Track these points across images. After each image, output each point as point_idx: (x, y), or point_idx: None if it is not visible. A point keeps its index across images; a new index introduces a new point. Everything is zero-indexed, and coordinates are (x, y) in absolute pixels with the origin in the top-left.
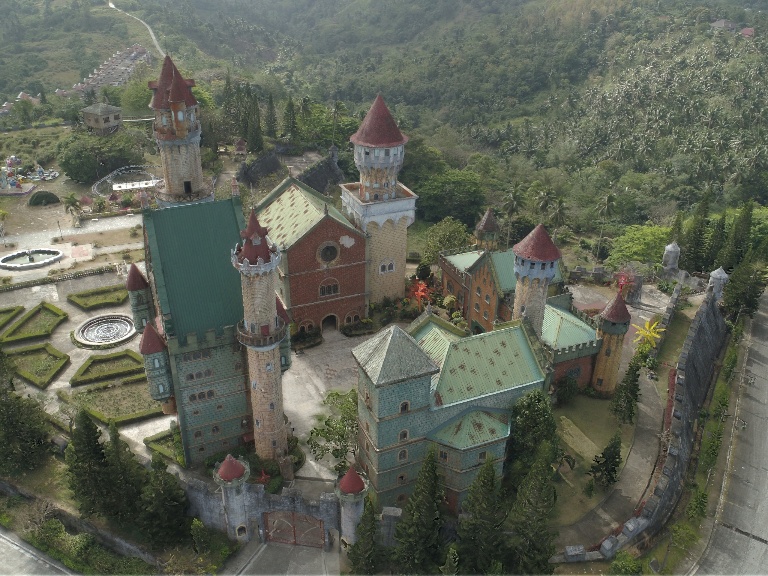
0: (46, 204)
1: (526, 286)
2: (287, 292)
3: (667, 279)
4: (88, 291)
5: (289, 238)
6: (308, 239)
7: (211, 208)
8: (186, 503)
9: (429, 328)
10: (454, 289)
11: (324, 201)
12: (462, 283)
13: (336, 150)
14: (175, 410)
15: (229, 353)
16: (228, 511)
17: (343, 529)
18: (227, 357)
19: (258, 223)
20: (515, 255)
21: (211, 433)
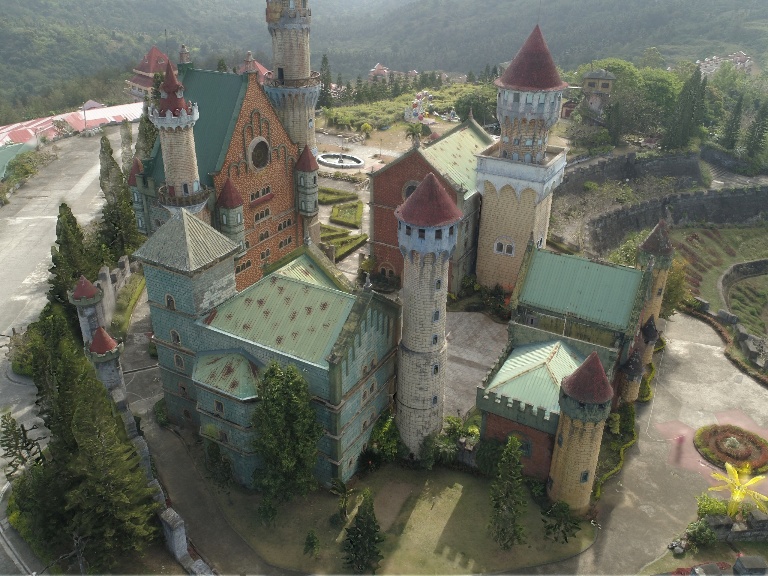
0: None
1: None
2: (371, 222)
3: None
4: (319, 187)
5: None
6: (395, 170)
7: (228, 79)
8: None
9: None
10: None
11: None
12: None
13: None
14: None
15: None
16: None
17: None
18: None
19: (172, 78)
20: None
21: None
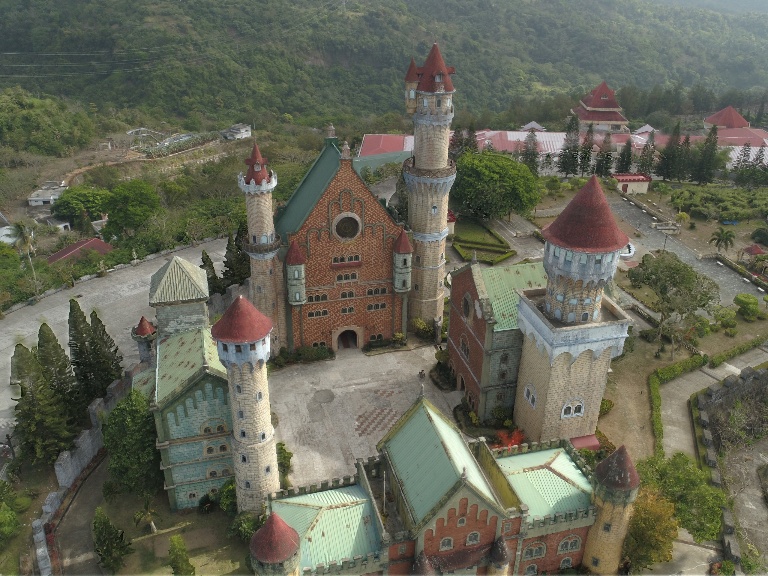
0: (758, 242)
1: None
2: None
3: None
4: None
5: None
6: None
7: None
8: None
9: None
10: None
11: None
12: None
13: None
14: None
15: None
16: None
17: None
18: None
19: (255, 154)
20: None
21: None
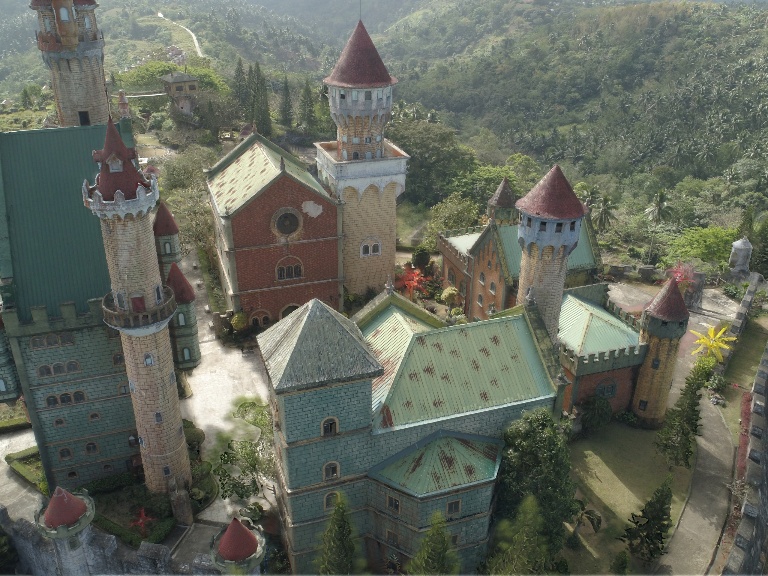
0: None
1: (534, 258)
2: (233, 272)
3: (734, 284)
4: None
5: (238, 202)
6: (259, 203)
7: (88, 135)
8: (8, 555)
9: (388, 313)
10: (456, 279)
11: (298, 166)
12: (464, 270)
13: None
14: None
15: (102, 339)
16: (62, 572)
17: None
18: (100, 345)
19: (120, 140)
20: None
21: (85, 452)
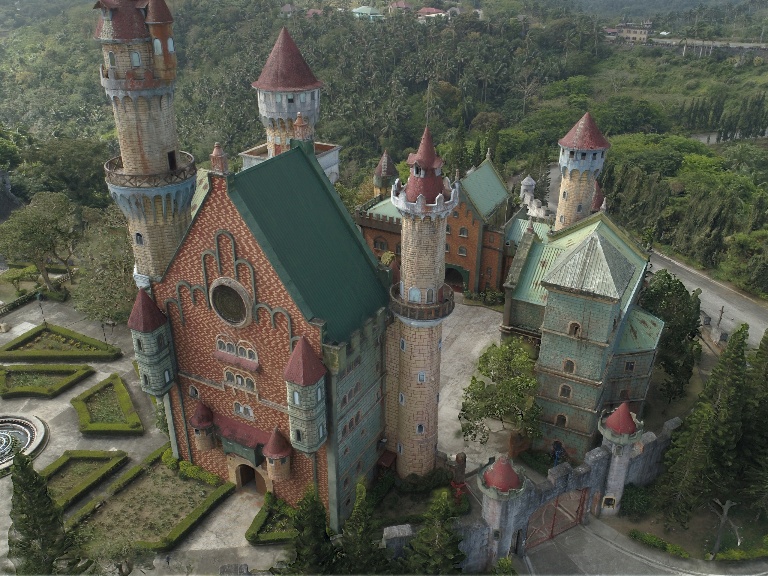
0: None
1: (584, 182)
2: None
3: None
4: None
5: None
6: None
7: (284, 163)
8: None
9: (540, 247)
10: (388, 244)
11: None
12: None
13: (6, 174)
14: (290, 470)
15: (372, 351)
16: (503, 534)
17: (612, 484)
18: (370, 358)
19: None
20: (573, 151)
21: (355, 474)
